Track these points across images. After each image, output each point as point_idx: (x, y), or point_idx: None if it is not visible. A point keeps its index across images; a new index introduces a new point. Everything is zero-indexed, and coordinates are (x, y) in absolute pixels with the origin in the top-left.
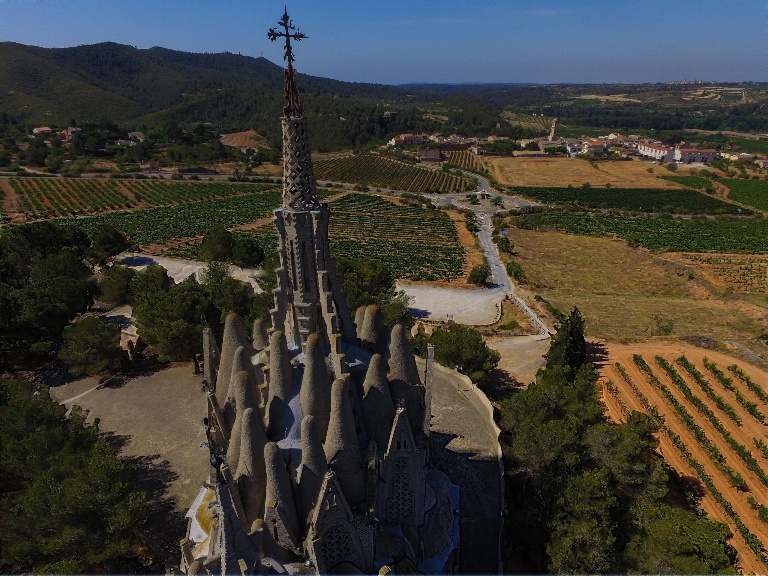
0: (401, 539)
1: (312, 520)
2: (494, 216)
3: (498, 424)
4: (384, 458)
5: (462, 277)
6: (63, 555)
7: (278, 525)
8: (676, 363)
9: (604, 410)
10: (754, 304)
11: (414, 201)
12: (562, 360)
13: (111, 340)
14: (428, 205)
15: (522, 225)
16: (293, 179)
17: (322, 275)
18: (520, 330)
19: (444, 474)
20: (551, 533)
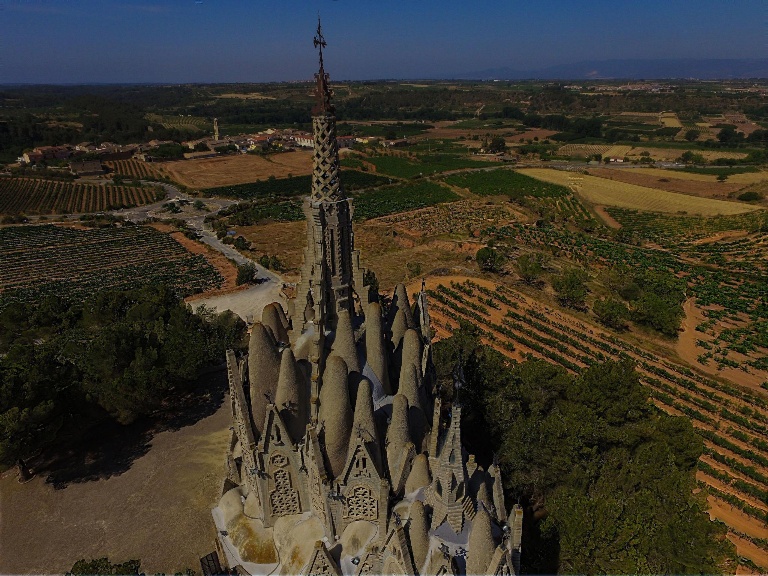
0: None
1: (431, 445)
2: (206, 220)
3: None
4: None
5: (224, 282)
6: None
7: None
8: (436, 291)
9: None
10: (444, 241)
11: (101, 222)
12: None
13: None
14: (124, 223)
15: (242, 222)
16: (331, 172)
17: None
18: None
19: None
20: (485, 408)
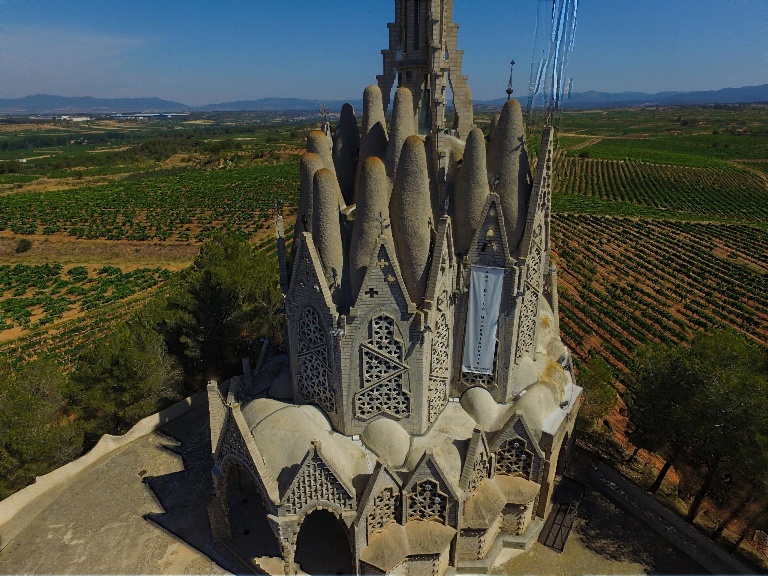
0: None
1: None
2: None
3: None
4: None
5: None
6: None
7: None
8: None
9: None
10: None
11: None
12: None
13: None
14: None
15: None
16: None
17: None
18: None
19: None
20: None
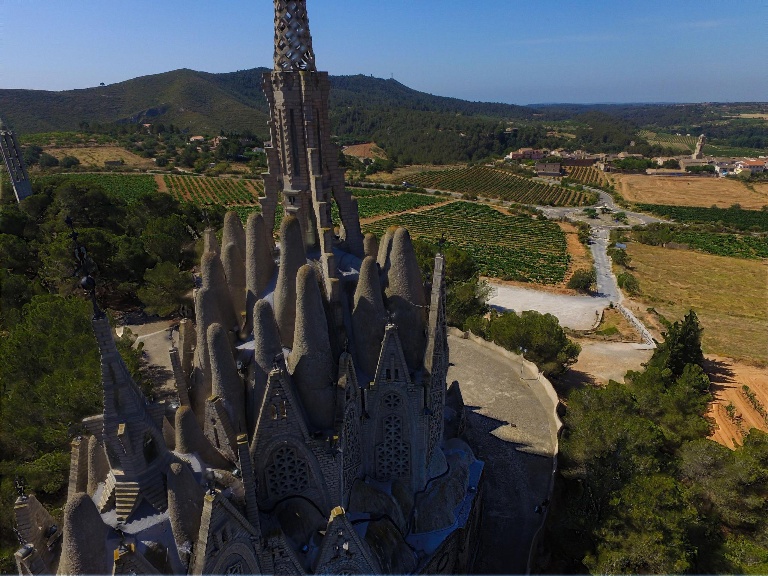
0: (387, 497)
1: None
2: None
3: (562, 418)
4: (370, 387)
5: (562, 284)
6: (63, 448)
7: (218, 426)
8: None
9: (713, 428)
10: None
11: None
12: (664, 366)
13: (184, 287)
14: (538, 216)
15: (645, 240)
16: (282, 31)
17: (310, 152)
18: (619, 336)
19: (466, 444)
20: (598, 544)
